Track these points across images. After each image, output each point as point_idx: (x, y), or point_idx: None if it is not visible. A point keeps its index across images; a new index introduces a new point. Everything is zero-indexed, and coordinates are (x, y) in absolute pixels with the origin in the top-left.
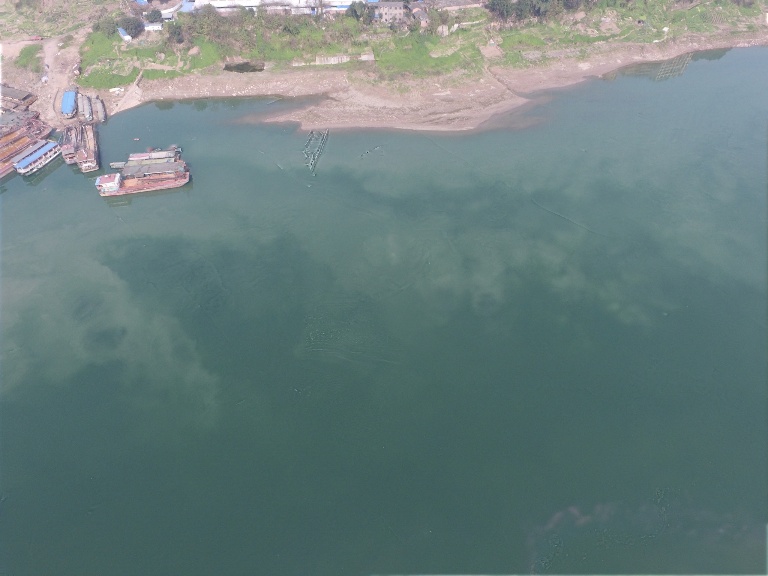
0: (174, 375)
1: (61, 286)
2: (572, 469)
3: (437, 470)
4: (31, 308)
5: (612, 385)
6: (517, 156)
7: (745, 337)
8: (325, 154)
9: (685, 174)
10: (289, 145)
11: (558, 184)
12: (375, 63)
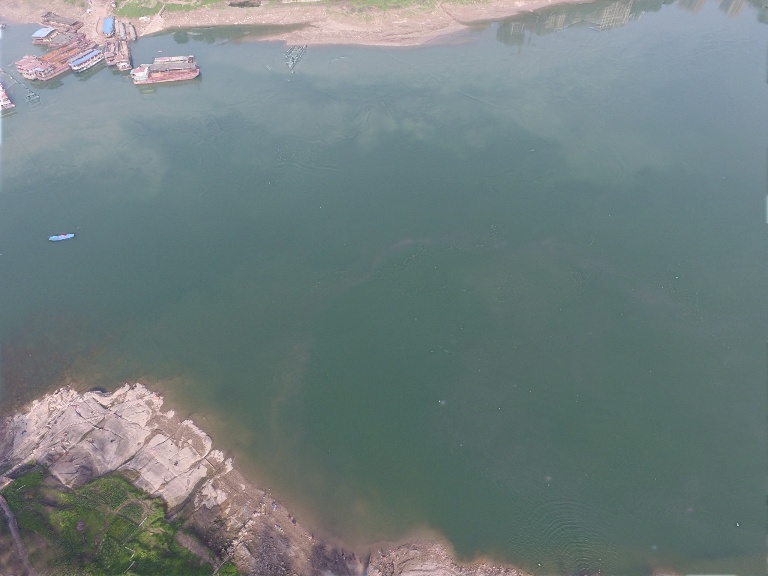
0: (186, 176)
1: (108, 132)
2: (443, 222)
3: (353, 218)
4: (88, 143)
5: (478, 178)
6: (450, 61)
7: (578, 155)
8: (303, 60)
9: (577, 72)
10: (275, 54)
11: (478, 79)
12: (349, 0)
